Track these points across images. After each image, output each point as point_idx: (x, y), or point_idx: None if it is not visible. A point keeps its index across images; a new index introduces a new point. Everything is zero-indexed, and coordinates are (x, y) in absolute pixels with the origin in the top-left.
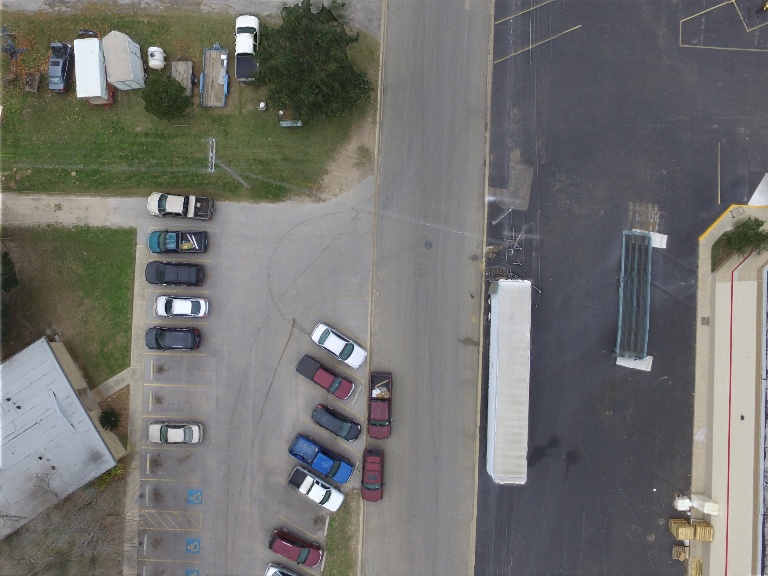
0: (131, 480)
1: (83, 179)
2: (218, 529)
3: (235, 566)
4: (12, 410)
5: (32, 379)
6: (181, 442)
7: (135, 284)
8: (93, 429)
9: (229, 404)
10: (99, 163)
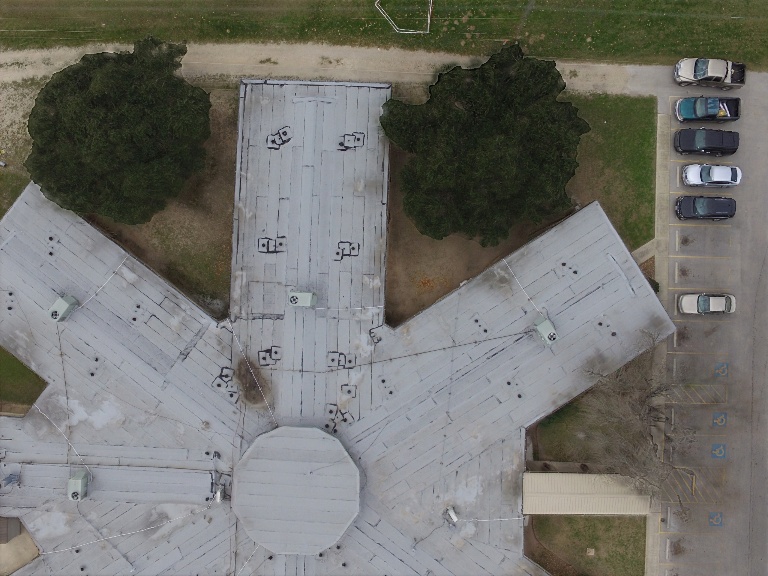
0: (658, 353)
1: (599, 45)
2: (744, 402)
3: (760, 439)
4: (566, 275)
5: (587, 243)
6: (719, 312)
7: (657, 154)
8: (653, 294)
9: (754, 276)
10: (617, 29)
